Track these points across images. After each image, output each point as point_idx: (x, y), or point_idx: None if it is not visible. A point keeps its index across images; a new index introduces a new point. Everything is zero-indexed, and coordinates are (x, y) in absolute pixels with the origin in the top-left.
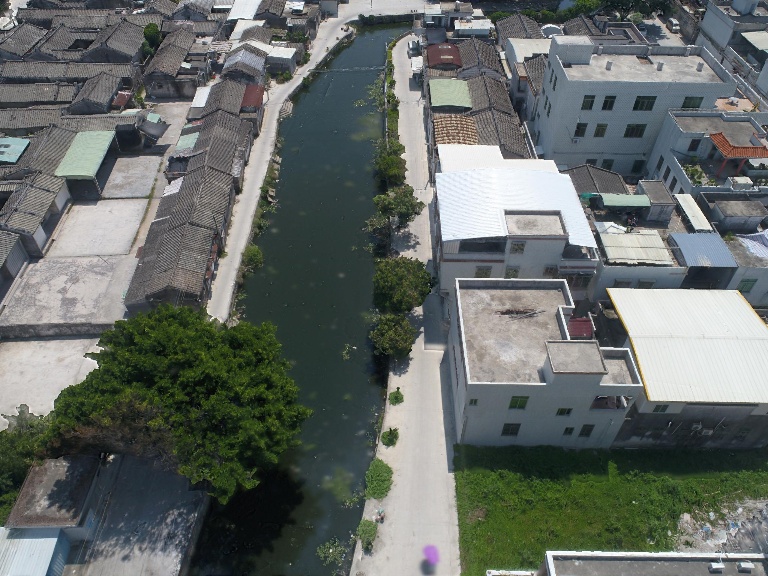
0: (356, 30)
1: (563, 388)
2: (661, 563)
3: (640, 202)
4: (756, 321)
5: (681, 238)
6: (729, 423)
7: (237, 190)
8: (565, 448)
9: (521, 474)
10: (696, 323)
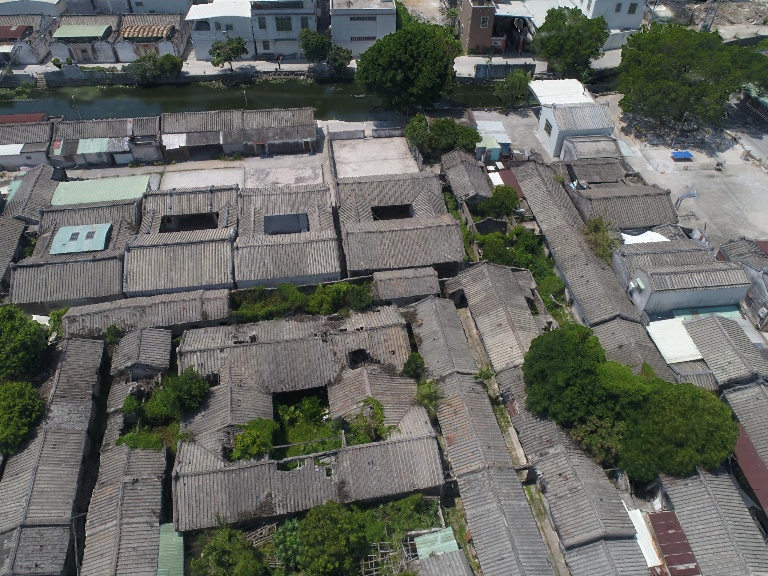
0: None
1: None
2: None
3: None
4: None
5: None
6: None
7: None
8: None
9: None
10: None
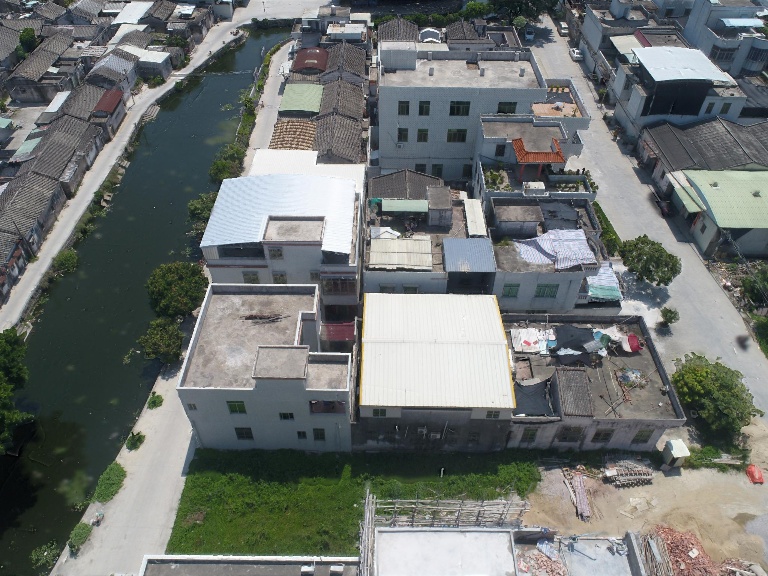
0: (248, 34)
1: (272, 393)
2: (257, 566)
3: (418, 207)
4: (496, 326)
5: (451, 243)
6: (455, 427)
7: (69, 195)
8: (307, 452)
9: (250, 477)
10: (435, 328)
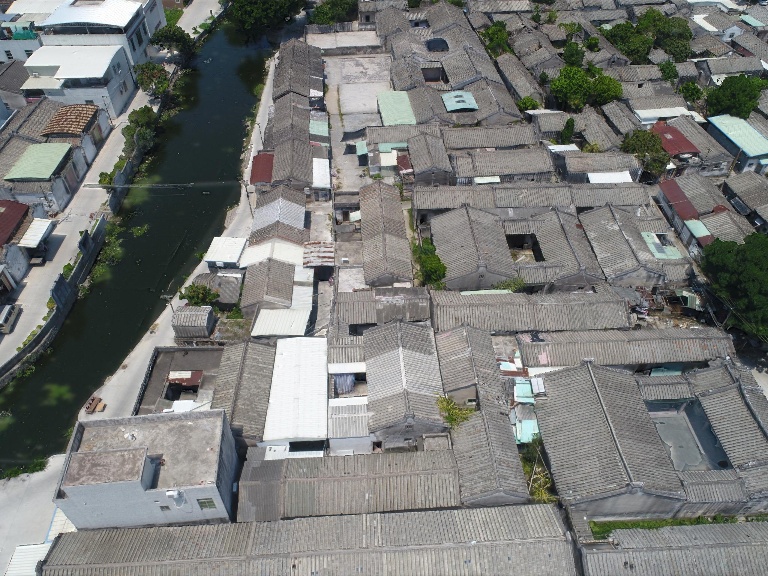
0: None
1: None
2: None
3: None
4: (13, 7)
5: (6, 20)
6: None
7: None
8: None
9: None
10: None
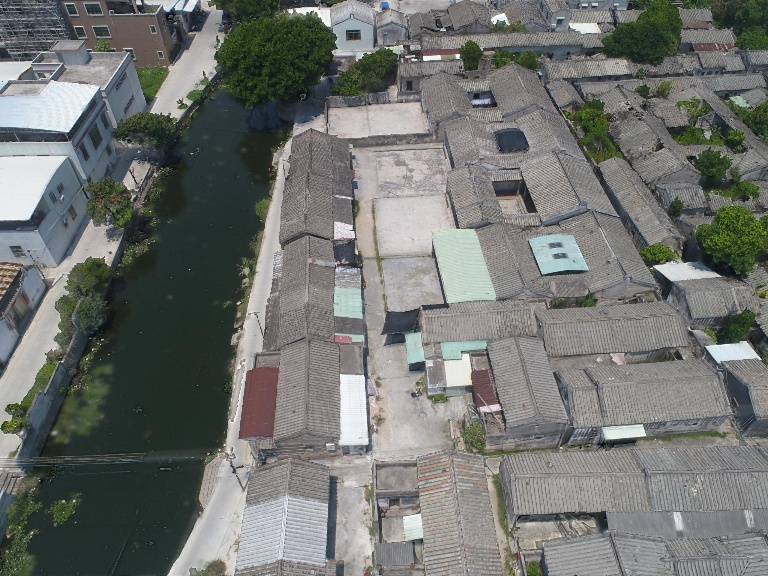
0: None
1: None
2: None
3: None
4: None
5: None
6: None
7: None
8: None
9: None
10: None
